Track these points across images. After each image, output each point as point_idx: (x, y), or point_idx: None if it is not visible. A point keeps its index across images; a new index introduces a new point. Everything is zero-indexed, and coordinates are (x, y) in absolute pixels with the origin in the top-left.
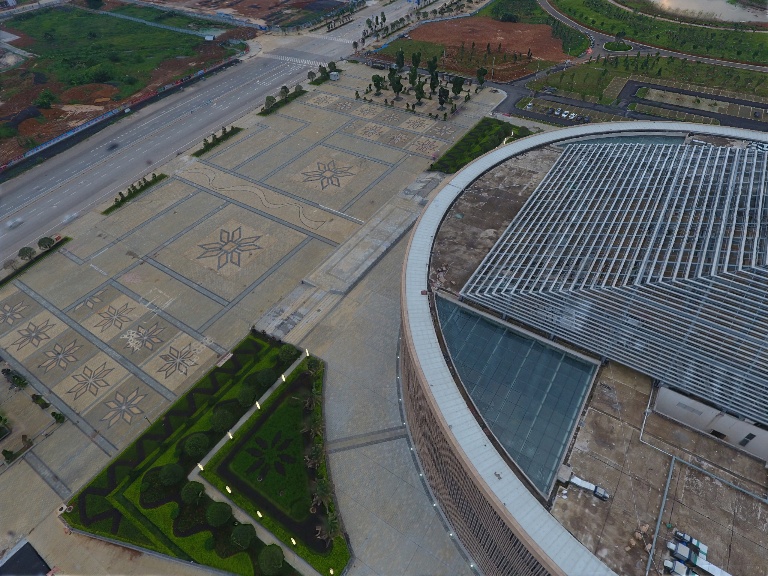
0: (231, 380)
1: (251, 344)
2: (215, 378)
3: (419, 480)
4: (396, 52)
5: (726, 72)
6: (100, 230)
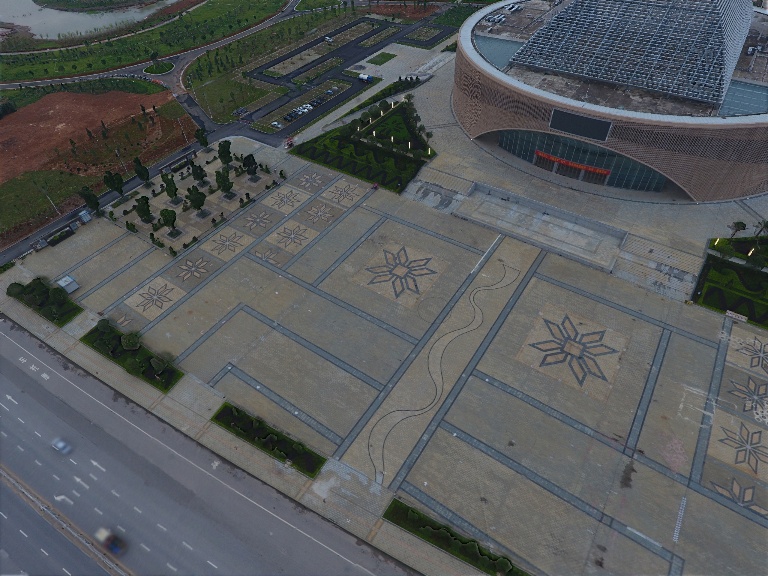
0: (760, 301)
1: (711, 296)
2: (765, 314)
3: (766, 196)
4: (81, 194)
5: (254, 40)
6: (586, 570)
